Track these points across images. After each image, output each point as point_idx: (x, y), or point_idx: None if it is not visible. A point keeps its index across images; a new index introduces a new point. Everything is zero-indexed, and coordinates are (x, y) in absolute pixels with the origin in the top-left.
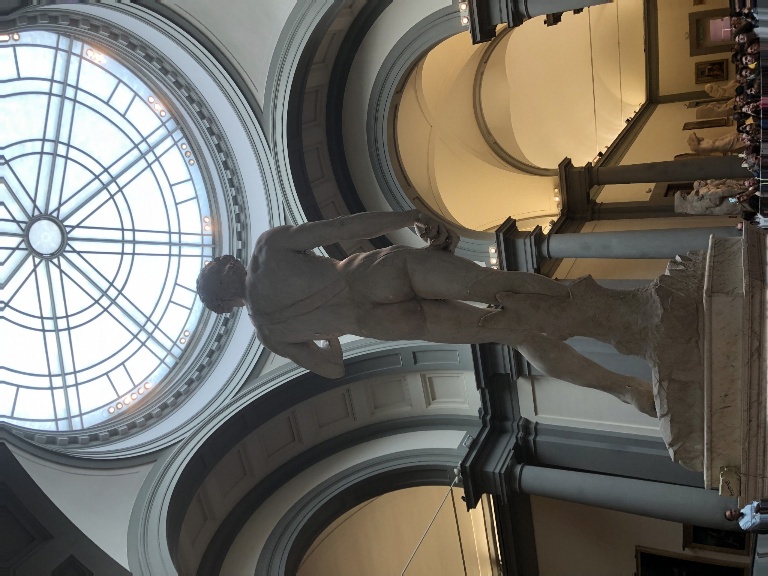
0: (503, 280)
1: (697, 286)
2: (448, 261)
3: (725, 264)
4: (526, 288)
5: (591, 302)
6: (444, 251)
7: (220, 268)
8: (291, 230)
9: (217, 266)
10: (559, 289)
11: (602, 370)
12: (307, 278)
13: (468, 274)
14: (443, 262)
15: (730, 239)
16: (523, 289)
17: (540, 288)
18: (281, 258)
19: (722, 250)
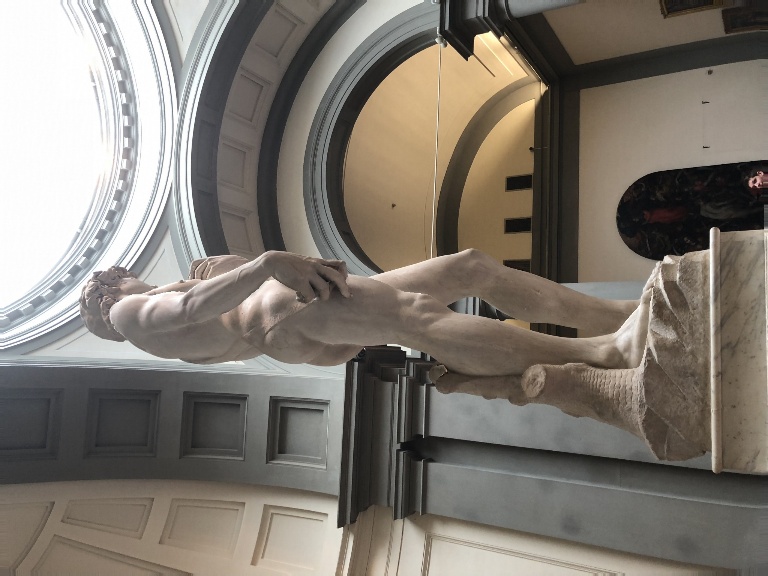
0: (434, 355)
1: (701, 410)
2: (350, 320)
3: (740, 357)
4: (468, 371)
5: (559, 406)
6: (336, 296)
7: (98, 320)
8: (141, 325)
9: (93, 318)
10: (510, 366)
11: (589, 316)
12: (203, 351)
13: (385, 335)
14: (345, 325)
15: (745, 245)
16: (465, 372)
17: (486, 371)
18: (158, 348)
19: (733, 295)
